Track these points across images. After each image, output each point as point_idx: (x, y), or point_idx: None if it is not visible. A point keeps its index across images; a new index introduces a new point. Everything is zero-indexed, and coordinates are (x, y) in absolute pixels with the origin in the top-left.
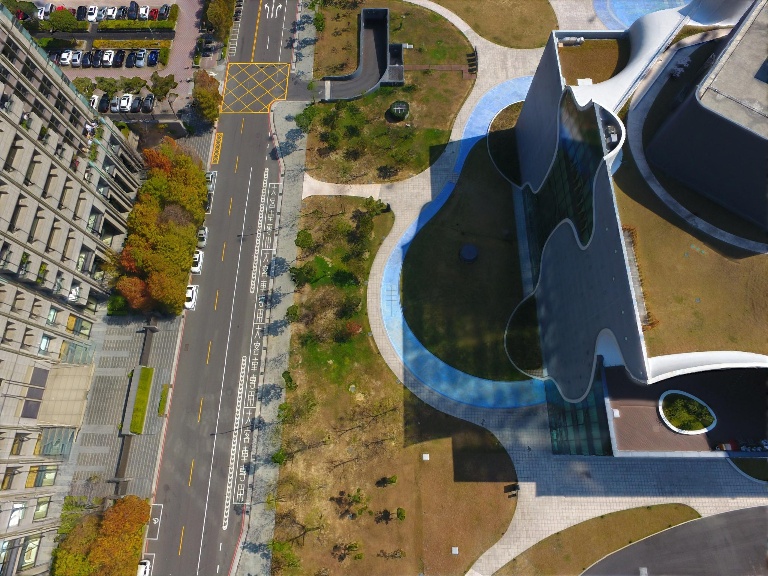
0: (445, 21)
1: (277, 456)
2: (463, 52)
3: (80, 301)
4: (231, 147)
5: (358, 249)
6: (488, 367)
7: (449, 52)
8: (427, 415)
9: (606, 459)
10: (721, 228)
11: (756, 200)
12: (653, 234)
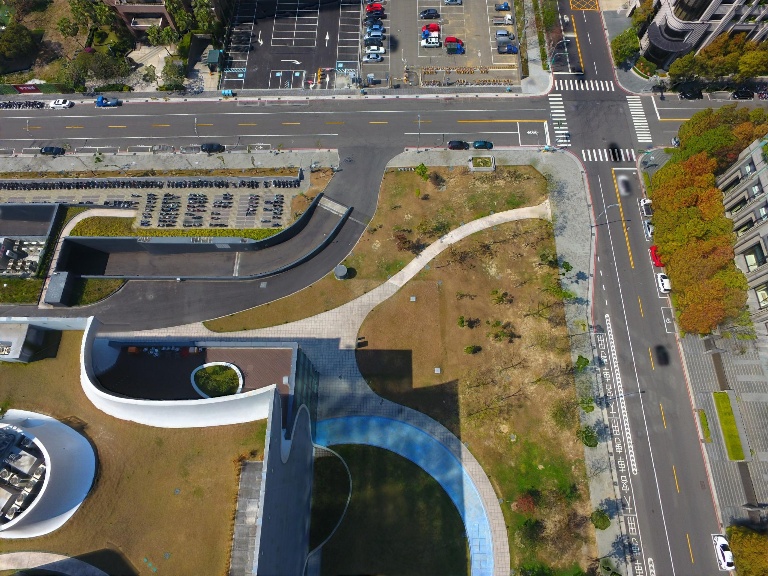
0: None
1: (585, 363)
2: None
3: None
4: None
5: None
6: (372, 460)
7: None
8: (436, 410)
9: None
10: None
11: None
12: None
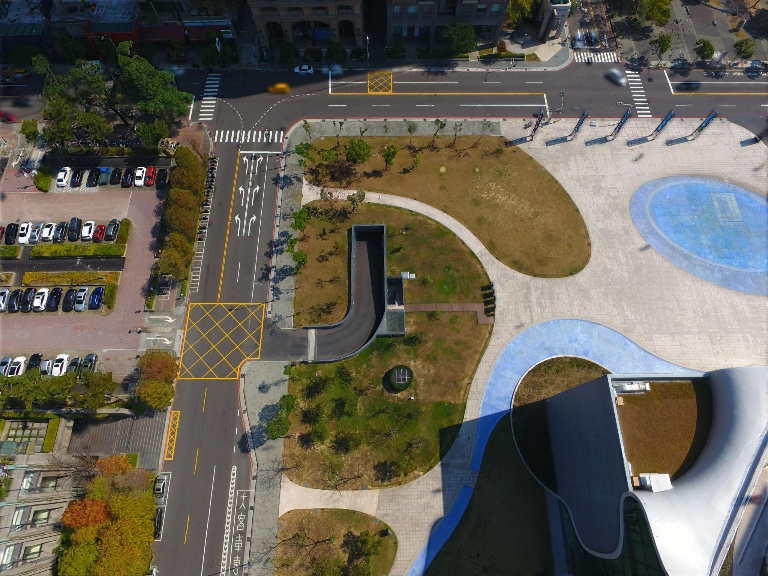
0: (453, 237)
1: None
2: (477, 283)
3: None
4: (190, 433)
5: None
6: None
7: (460, 284)
8: None
9: None
10: None
11: None
12: None
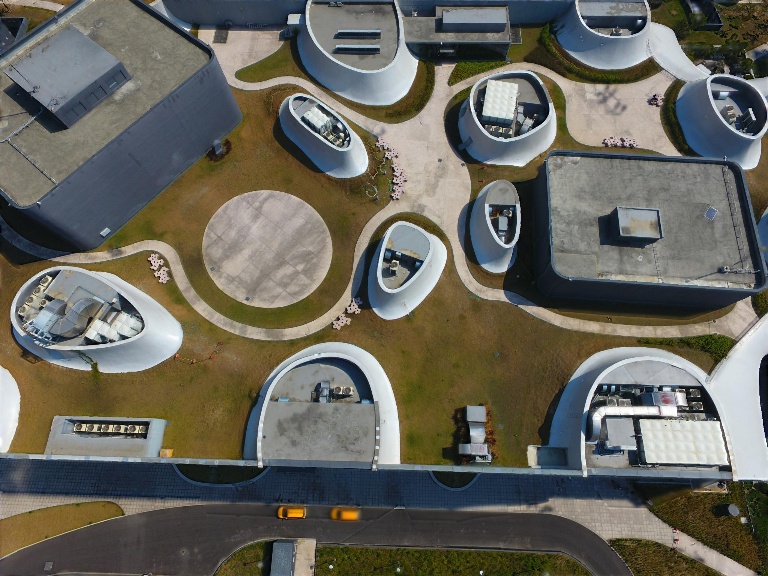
0: None
1: None
2: None
3: None
4: None
5: None
6: None
7: None
8: None
9: None
10: (21, 234)
11: None
12: None
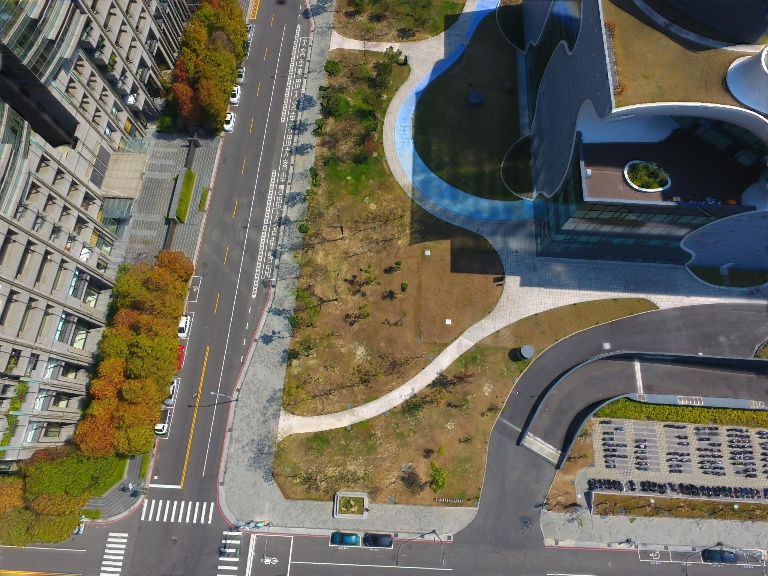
0: None
1: (303, 225)
2: None
3: (137, 104)
4: (268, 6)
5: (377, 93)
6: (485, 189)
7: None
8: (430, 222)
9: (582, 262)
10: (686, 29)
11: (716, 1)
12: (629, 30)
